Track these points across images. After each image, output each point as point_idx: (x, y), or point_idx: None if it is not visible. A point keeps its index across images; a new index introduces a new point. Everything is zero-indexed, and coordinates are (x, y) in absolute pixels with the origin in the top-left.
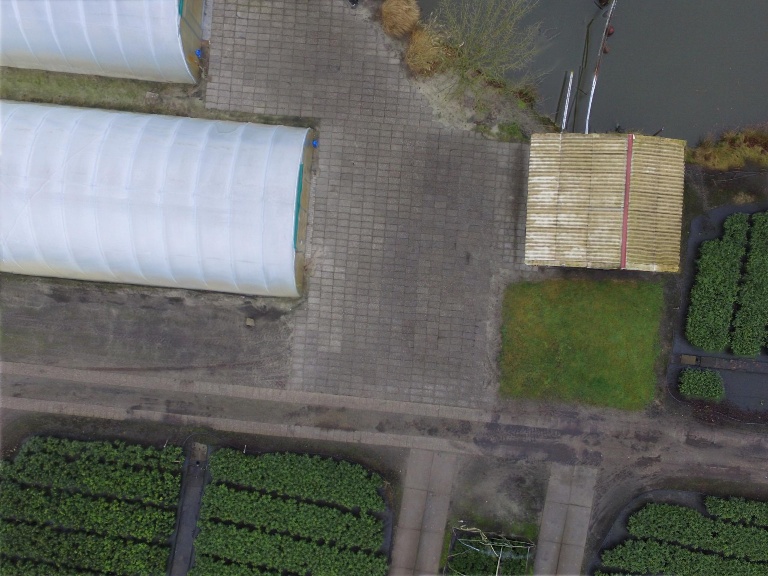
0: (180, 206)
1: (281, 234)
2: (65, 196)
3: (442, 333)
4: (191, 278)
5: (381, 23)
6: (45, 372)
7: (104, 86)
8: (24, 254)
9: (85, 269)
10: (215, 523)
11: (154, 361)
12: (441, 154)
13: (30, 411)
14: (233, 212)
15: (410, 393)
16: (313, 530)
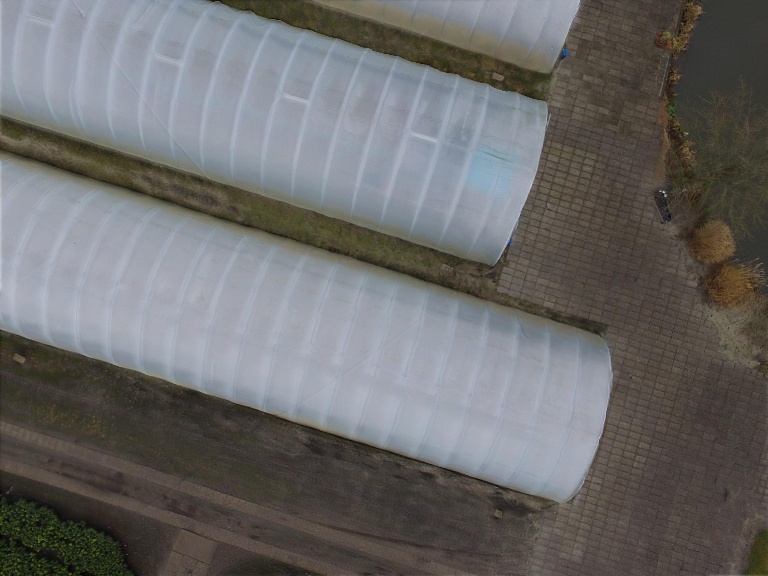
0: (487, 414)
1: (578, 461)
2: (377, 380)
3: (686, 566)
4: (462, 469)
5: (688, 245)
6: (287, 521)
7: (402, 249)
8: (309, 415)
9: (360, 438)
10: None
11: (397, 533)
12: (720, 386)
13: (265, 556)
14: (538, 431)
15: None
16: None
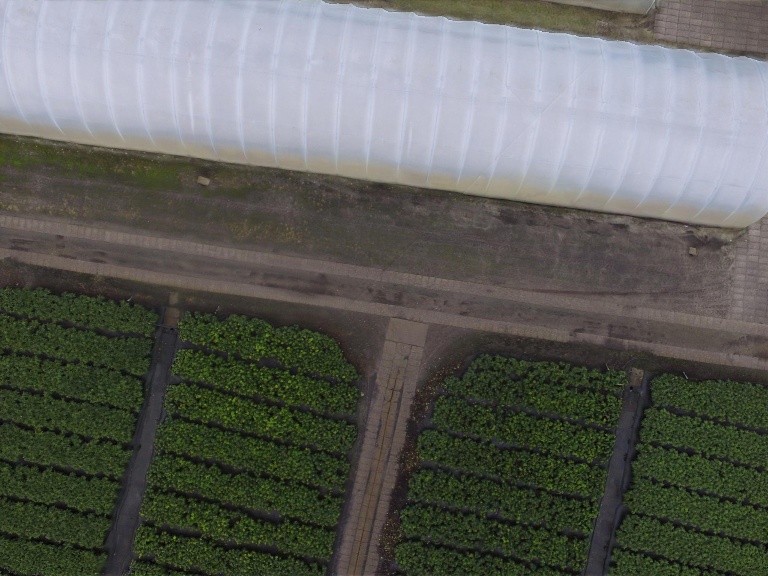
0: (686, 126)
1: None
2: (576, 111)
3: None
4: (658, 202)
5: None
6: (491, 292)
7: (555, 13)
8: (506, 171)
9: (555, 189)
10: (654, 447)
11: (598, 286)
12: None
13: (476, 330)
14: (738, 134)
15: None
16: (755, 457)
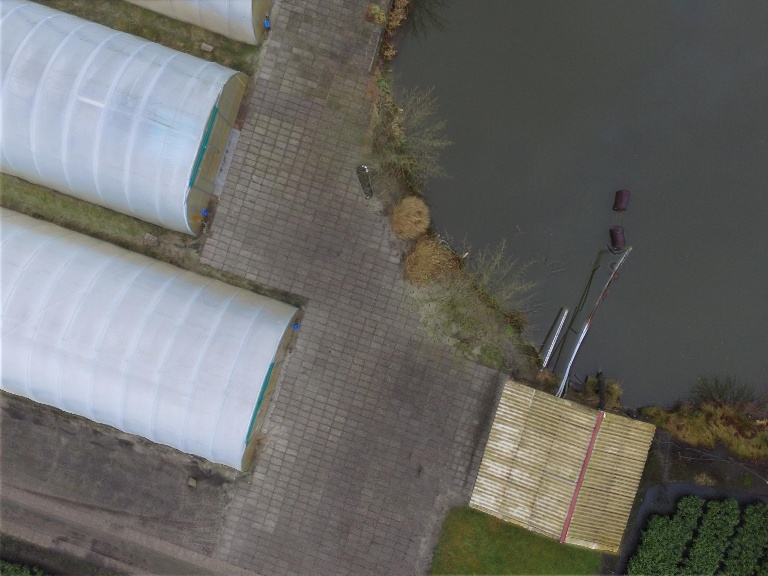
0: (144, 379)
1: (235, 428)
2: (35, 343)
3: (376, 539)
4: None
5: (390, 221)
6: None
7: (106, 217)
8: None
9: (42, 401)
10: None
11: (90, 498)
12: (418, 363)
13: None
14: (194, 397)
15: None
16: None
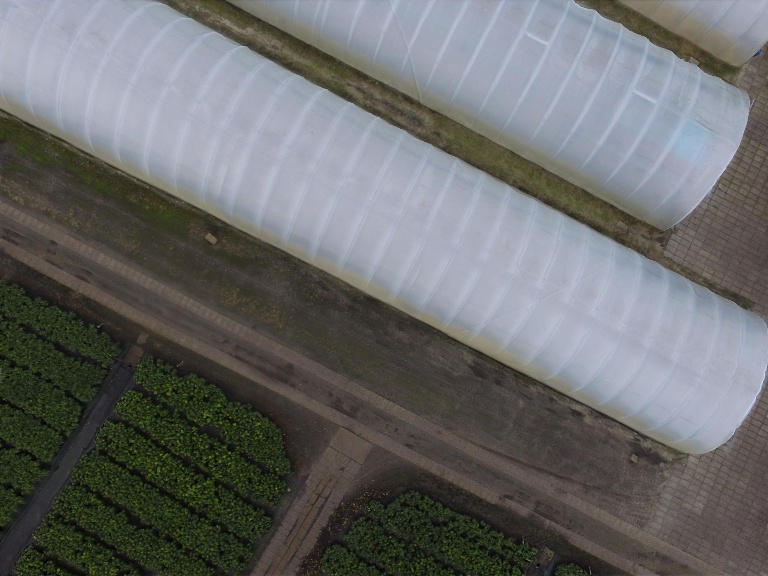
0: (663, 356)
1: (734, 412)
2: (570, 309)
3: None
4: (618, 408)
5: None
6: (442, 434)
7: (585, 201)
8: (492, 335)
9: (530, 364)
10: None
11: (540, 461)
12: None
13: (415, 465)
14: (705, 379)
15: (747, 574)
16: None
